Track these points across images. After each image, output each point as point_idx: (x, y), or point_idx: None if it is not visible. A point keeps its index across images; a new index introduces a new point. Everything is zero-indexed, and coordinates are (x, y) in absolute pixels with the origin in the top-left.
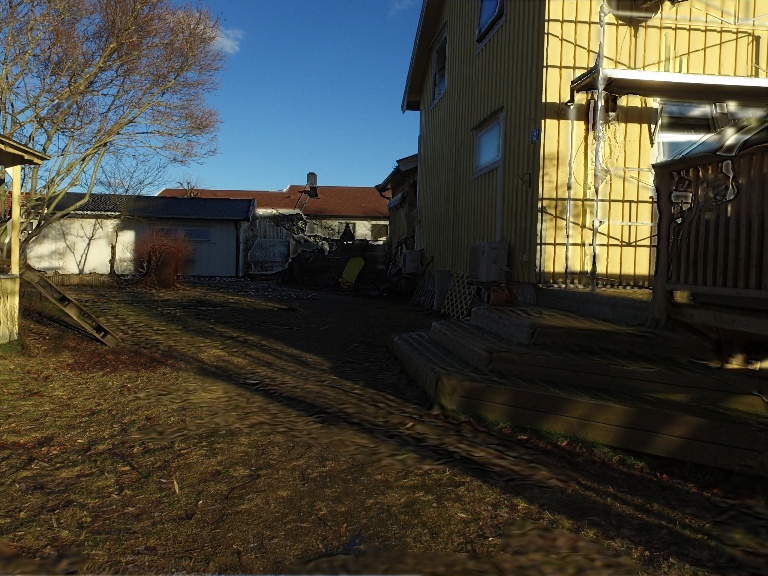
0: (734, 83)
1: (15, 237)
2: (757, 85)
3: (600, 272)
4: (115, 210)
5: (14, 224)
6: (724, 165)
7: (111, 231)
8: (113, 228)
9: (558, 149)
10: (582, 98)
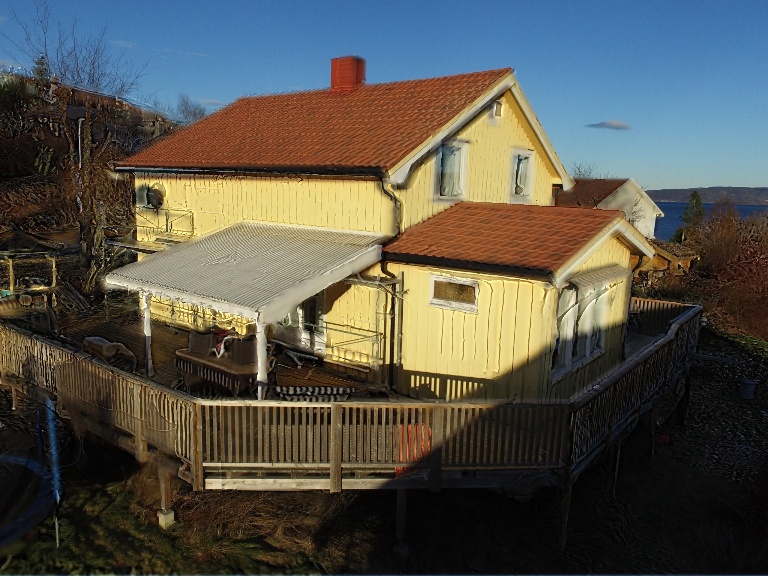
0: None
1: (55, 275)
2: None
3: (154, 313)
4: None
5: (54, 271)
6: None
7: None
8: None
9: None
10: (146, 239)
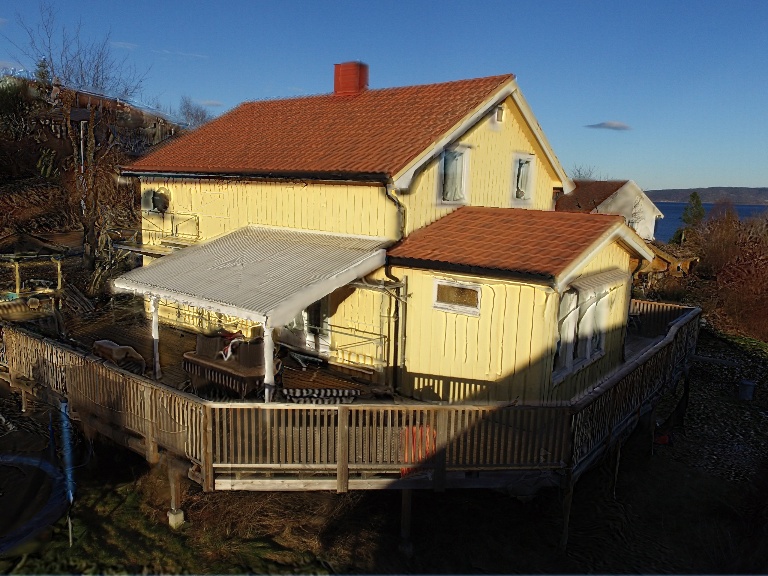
0: (141, 251)
1: (60, 277)
2: None
3: (159, 315)
4: None
5: (59, 273)
6: None
7: None
8: None
9: None
10: (152, 243)
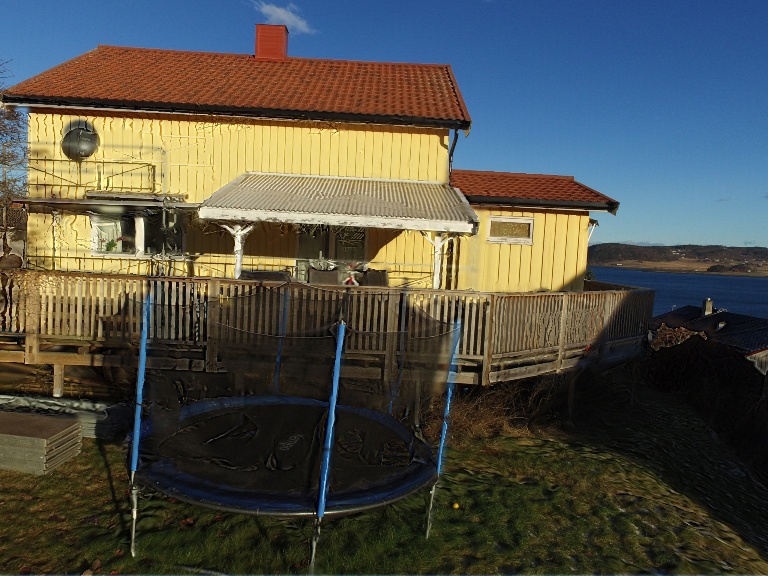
0: (82, 203)
1: None
2: (95, 204)
3: None
4: (12, 225)
5: None
6: (138, 238)
7: (10, 241)
8: (11, 238)
9: (38, 229)
10: None
